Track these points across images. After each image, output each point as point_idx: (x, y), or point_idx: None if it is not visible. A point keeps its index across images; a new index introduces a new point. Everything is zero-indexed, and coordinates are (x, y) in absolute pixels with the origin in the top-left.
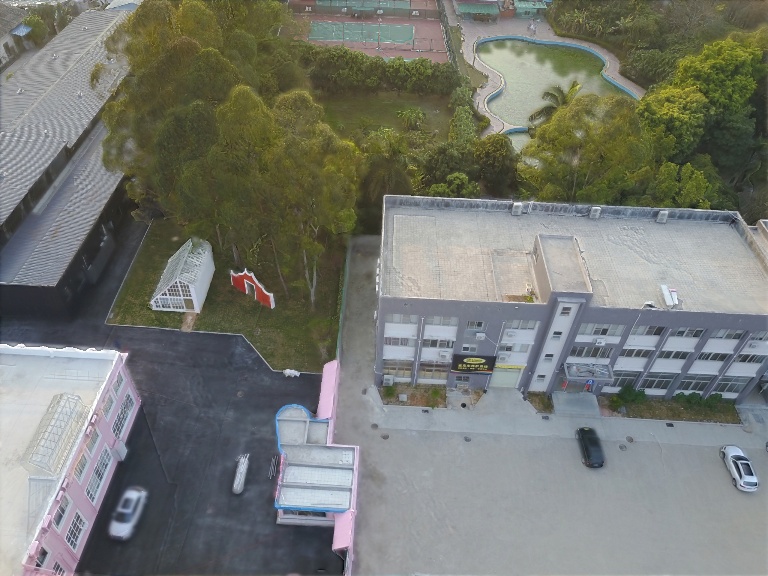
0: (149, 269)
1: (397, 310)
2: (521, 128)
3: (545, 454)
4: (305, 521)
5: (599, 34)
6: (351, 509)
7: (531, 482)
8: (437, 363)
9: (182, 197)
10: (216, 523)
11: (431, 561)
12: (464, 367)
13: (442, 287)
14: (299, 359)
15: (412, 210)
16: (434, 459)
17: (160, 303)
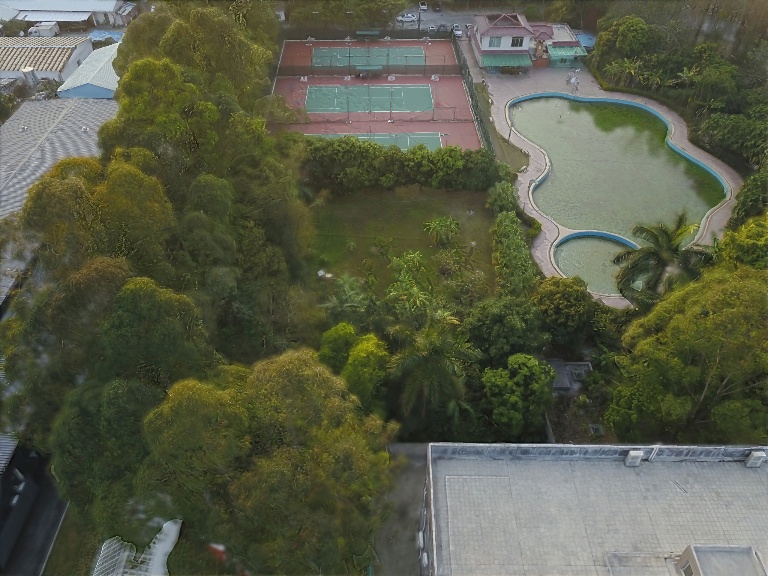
0: (87, 525)
1: None
2: (581, 232)
3: None
4: None
5: (655, 87)
6: None
7: None
8: None
9: None
10: None
11: None
12: None
13: None
14: None
15: (472, 463)
16: None
17: None
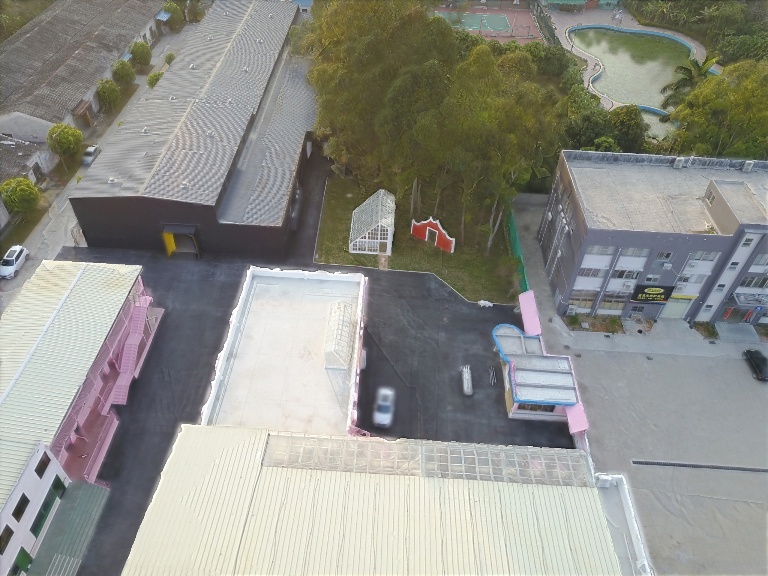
0: (335, 219)
1: (599, 241)
2: None
3: (720, 370)
4: (533, 416)
5: (682, 23)
6: (580, 402)
7: (712, 392)
8: (618, 294)
9: (411, 144)
10: (458, 417)
11: (643, 450)
12: (643, 297)
13: (633, 224)
14: (488, 293)
15: (585, 164)
16: (625, 373)
17: (357, 246)
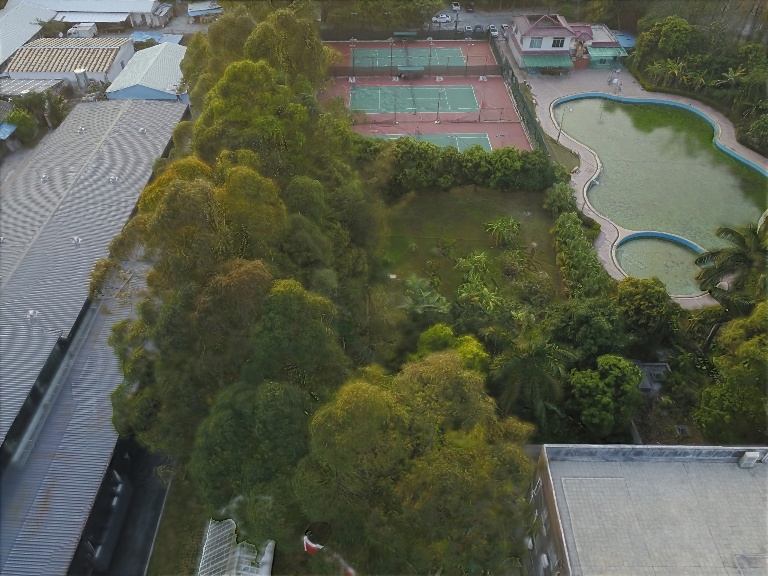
0: (184, 527)
1: None
2: (640, 233)
3: None
4: None
5: (699, 87)
6: None
7: None
8: None
9: (247, 528)
10: None
11: None
12: None
13: None
14: None
15: (585, 465)
16: None
17: None
